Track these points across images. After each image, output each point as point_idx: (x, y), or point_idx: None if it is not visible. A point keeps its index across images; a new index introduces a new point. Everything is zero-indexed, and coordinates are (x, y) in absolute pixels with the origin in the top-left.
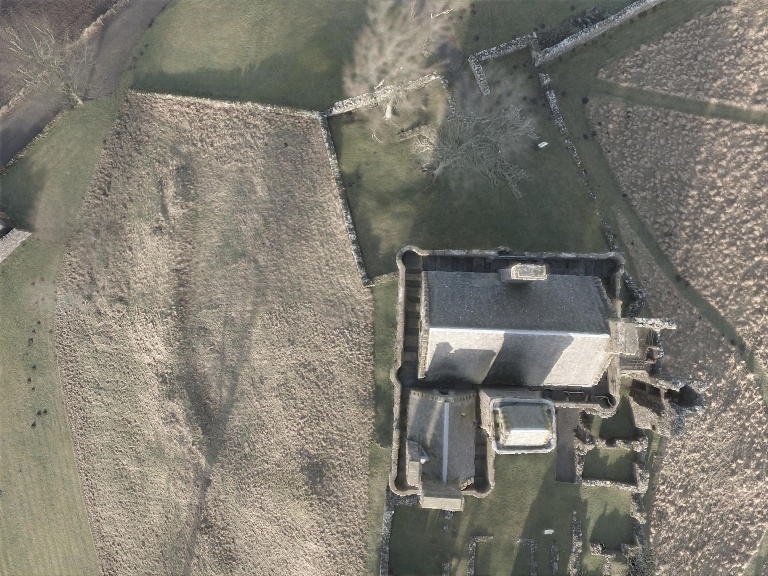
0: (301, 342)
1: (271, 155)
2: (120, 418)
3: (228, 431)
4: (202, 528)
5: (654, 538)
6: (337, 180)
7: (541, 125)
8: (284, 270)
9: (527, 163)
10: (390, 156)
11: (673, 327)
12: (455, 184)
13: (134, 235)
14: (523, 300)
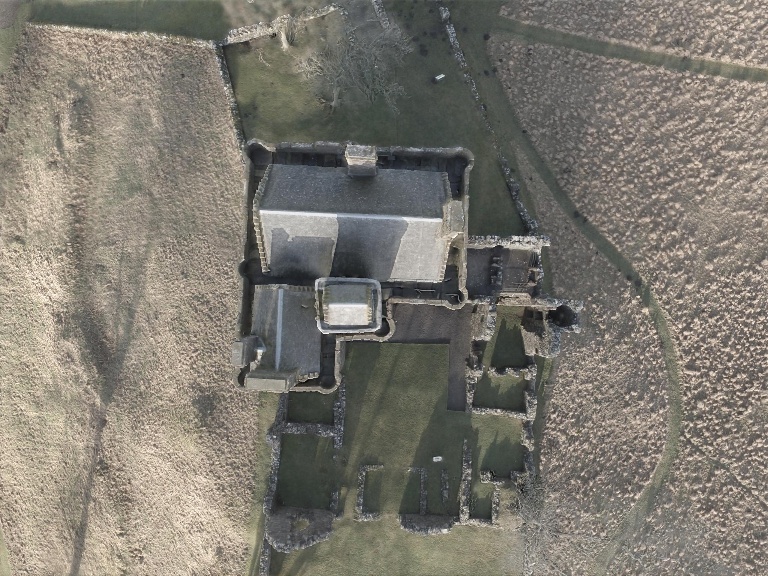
0: (195, 275)
1: (168, 86)
2: (18, 362)
3: (124, 370)
4: (98, 470)
5: (544, 466)
6: (233, 110)
7: (441, 59)
8: (179, 202)
9: (426, 96)
10: (288, 87)
11: (547, 243)
12: (353, 116)
13: (31, 172)
14: (364, 190)
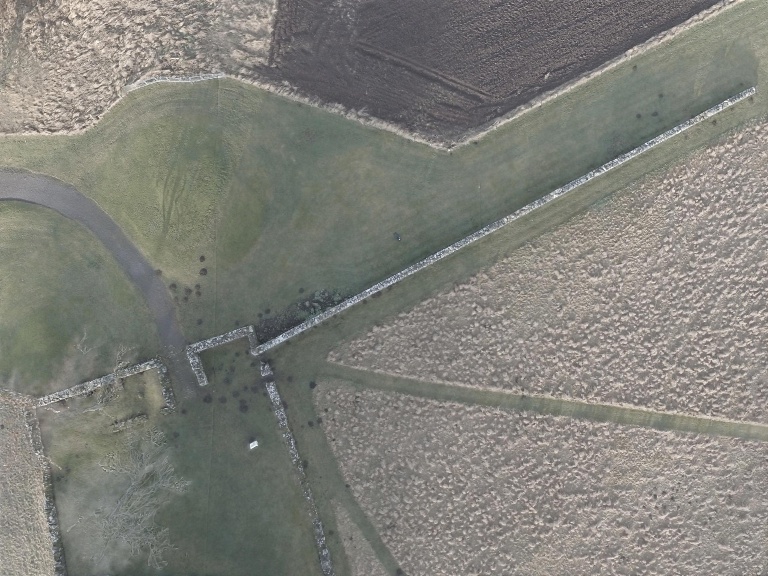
0: None
1: None
2: None
3: None
4: None
5: None
6: (44, 474)
7: (261, 416)
8: None
9: (242, 459)
10: (102, 448)
11: None
12: None
13: None
14: None
